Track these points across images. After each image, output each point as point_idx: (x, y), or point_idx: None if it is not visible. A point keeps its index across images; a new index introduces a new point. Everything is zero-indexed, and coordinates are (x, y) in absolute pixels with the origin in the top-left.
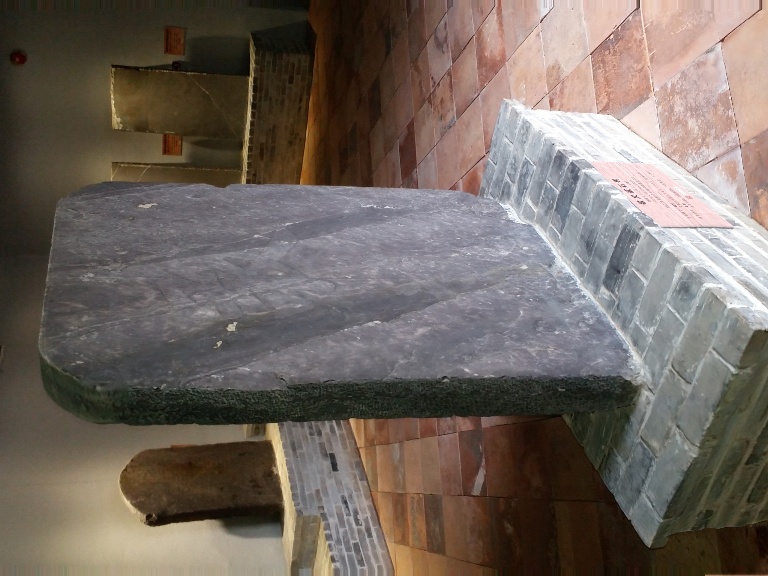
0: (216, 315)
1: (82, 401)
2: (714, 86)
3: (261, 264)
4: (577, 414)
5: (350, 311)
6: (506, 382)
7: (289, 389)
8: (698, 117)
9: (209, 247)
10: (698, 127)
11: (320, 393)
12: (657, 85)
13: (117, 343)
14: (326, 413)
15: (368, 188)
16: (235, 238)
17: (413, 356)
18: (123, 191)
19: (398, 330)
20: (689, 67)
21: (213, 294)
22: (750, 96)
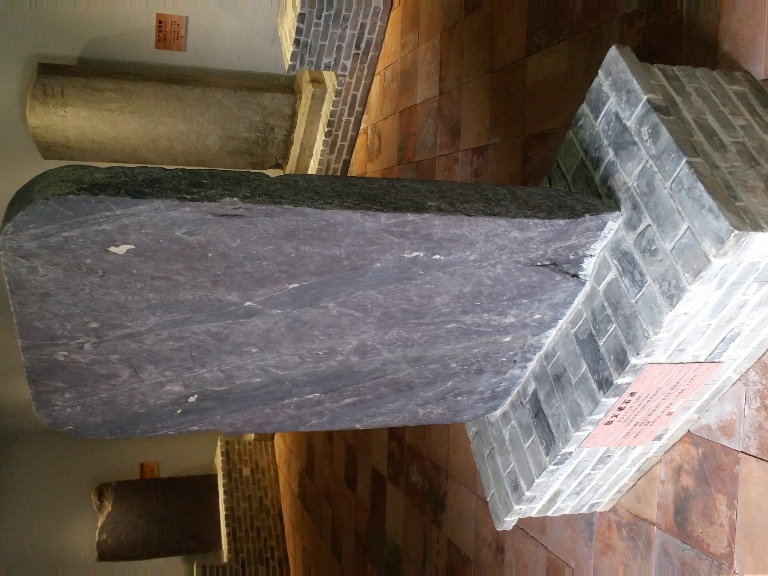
0: (181, 390)
1: None
2: None
3: (240, 337)
4: None
5: (300, 386)
6: None
7: None
8: None
9: (190, 318)
10: None
11: None
12: None
13: (97, 414)
14: None
15: (439, 219)
16: (222, 307)
17: (326, 417)
18: (86, 221)
19: (329, 400)
20: None
21: (183, 370)
22: None
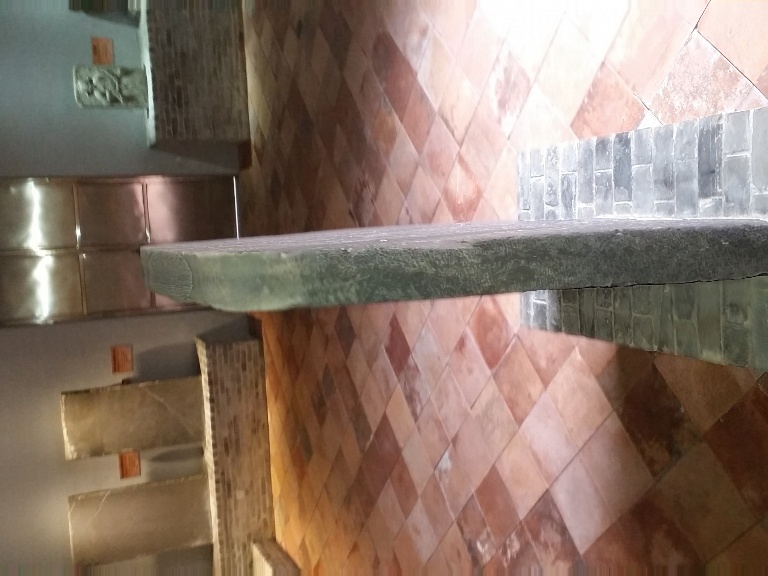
0: None
1: (264, 283)
2: (705, 62)
3: None
4: (727, 340)
5: None
6: (674, 234)
7: (475, 247)
8: (701, 94)
9: None
10: (705, 101)
11: (506, 252)
12: (649, 101)
13: None
14: (515, 282)
15: None
16: None
17: None
18: None
19: None
20: (674, 66)
21: None
22: (744, 44)
